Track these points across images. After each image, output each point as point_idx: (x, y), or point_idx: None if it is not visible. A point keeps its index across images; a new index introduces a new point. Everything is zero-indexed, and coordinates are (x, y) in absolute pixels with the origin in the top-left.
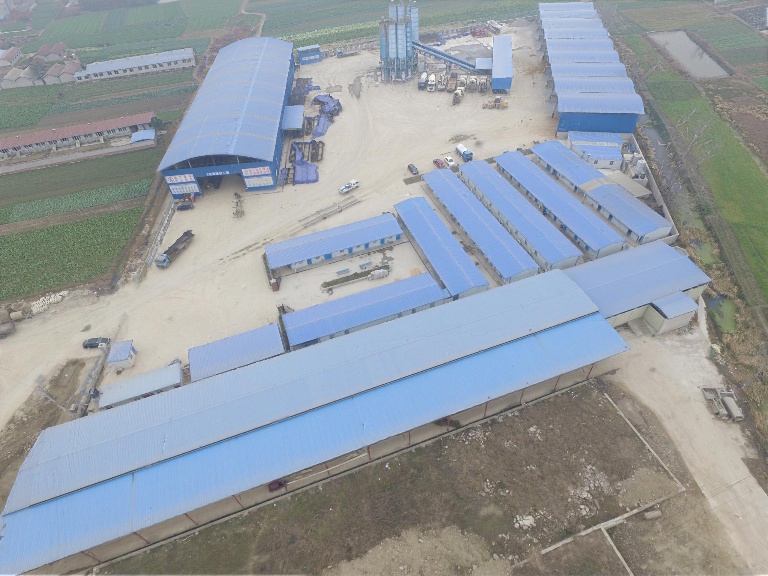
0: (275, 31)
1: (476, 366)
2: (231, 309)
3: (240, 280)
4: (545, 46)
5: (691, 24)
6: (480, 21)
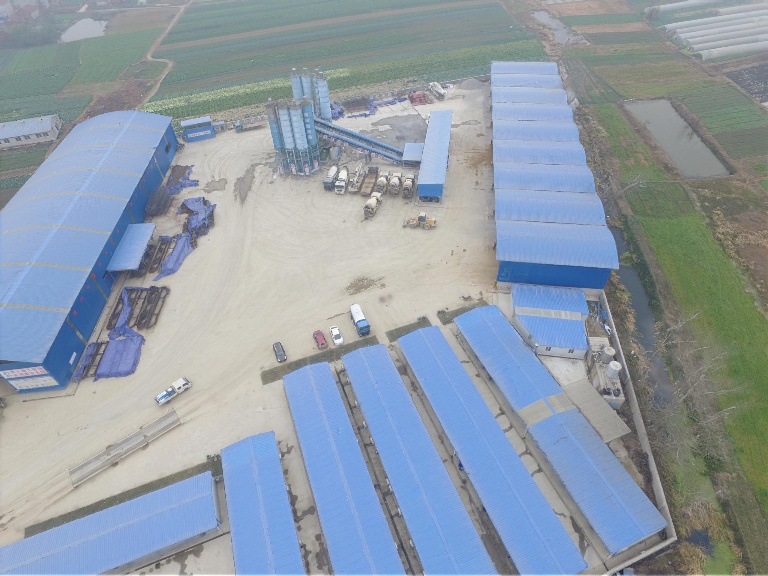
0: (175, 88)
1: None
2: None
3: None
4: None
5: (676, 90)
6: (423, 80)
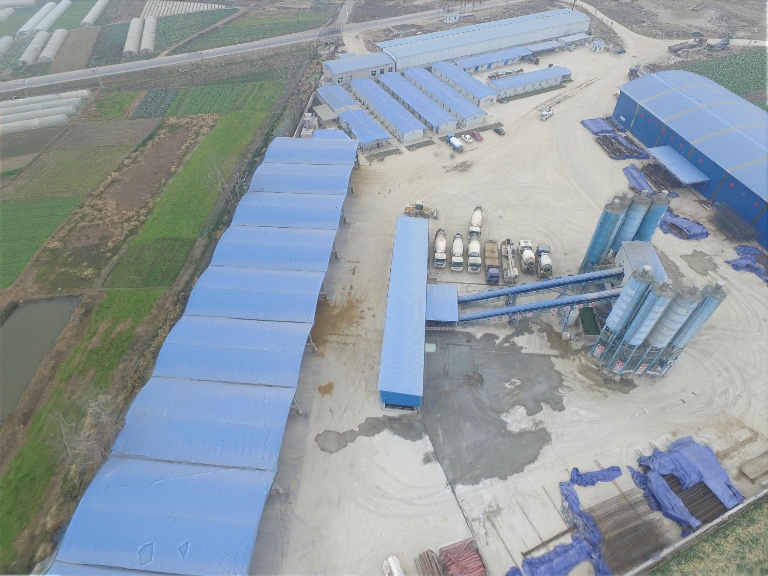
0: None
1: (438, 36)
2: (566, 64)
3: None
4: None
5: None
6: None
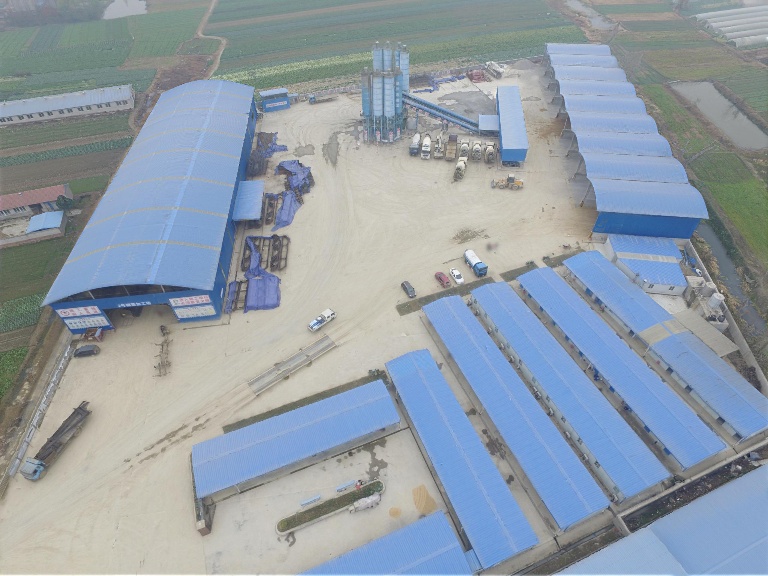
0: (236, 63)
1: None
2: None
3: (152, 508)
4: (561, 102)
5: (717, 73)
6: (477, 60)
